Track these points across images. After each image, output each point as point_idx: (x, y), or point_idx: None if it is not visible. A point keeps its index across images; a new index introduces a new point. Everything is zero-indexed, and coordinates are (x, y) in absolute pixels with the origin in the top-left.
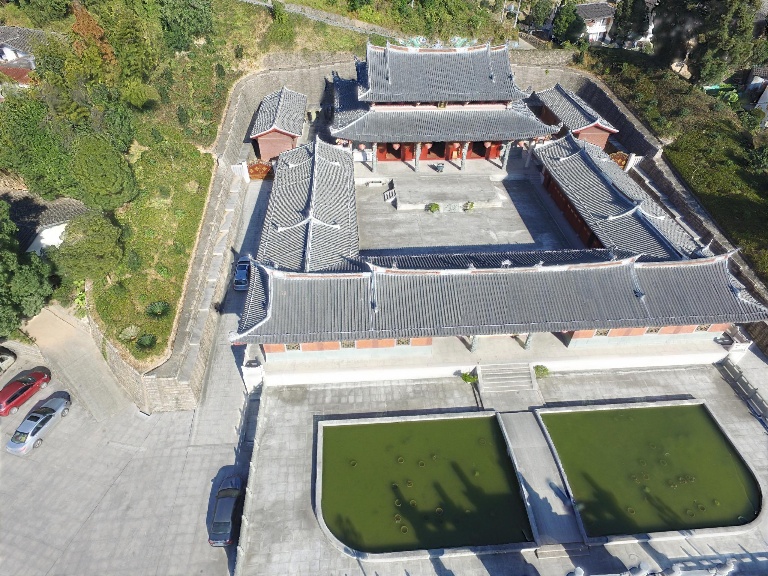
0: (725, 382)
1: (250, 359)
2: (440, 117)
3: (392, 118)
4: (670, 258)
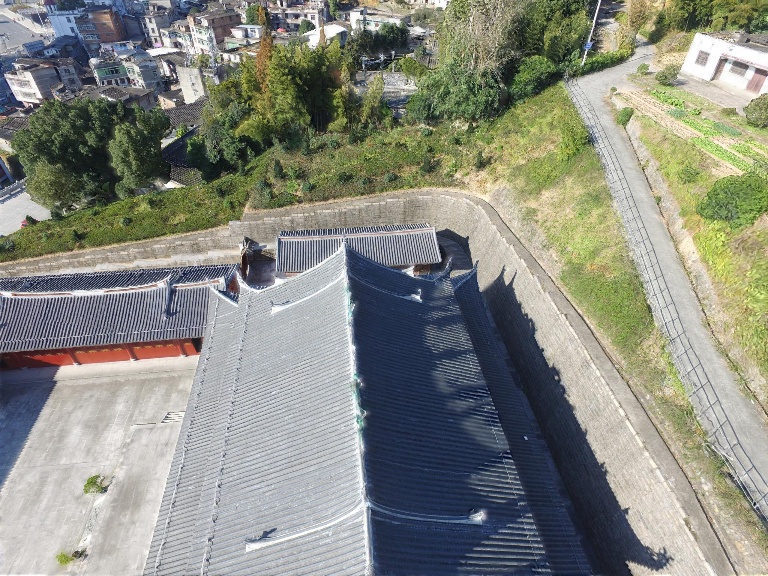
0: None
1: None
2: None
3: None
4: None
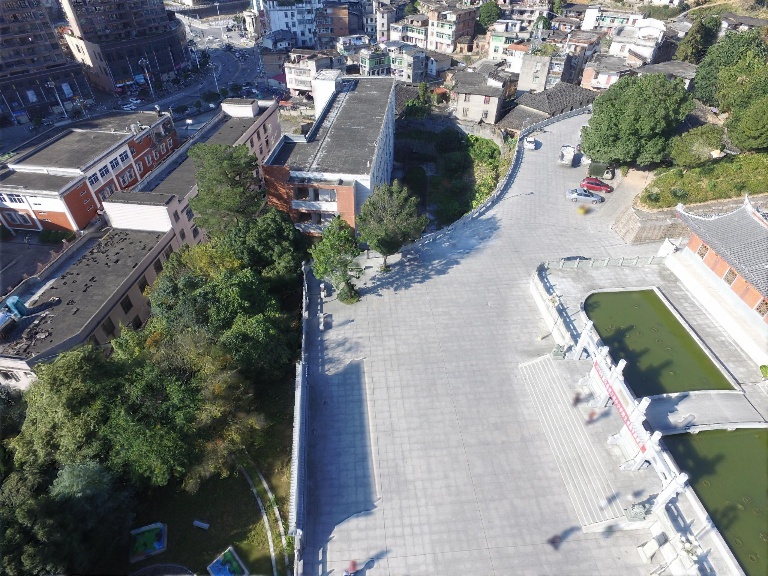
0: None
1: (678, 246)
2: None
3: None
4: None
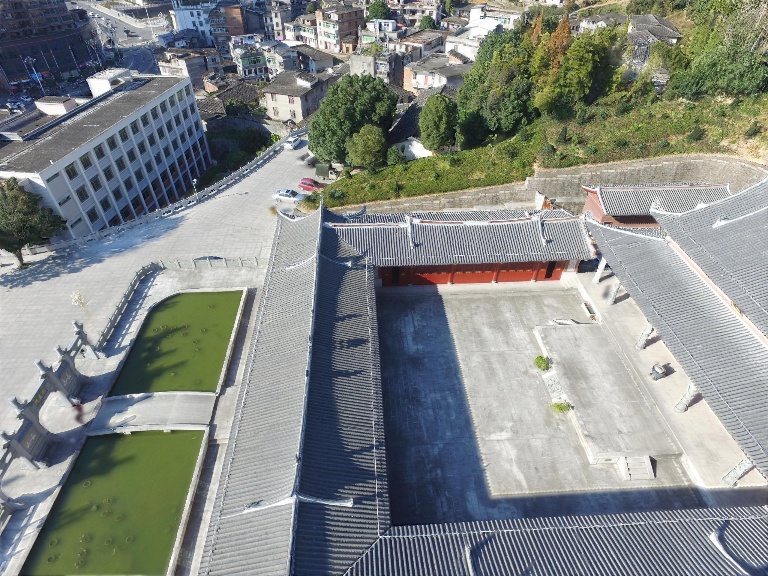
0: None
1: None
2: (716, 316)
3: (669, 264)
4: None
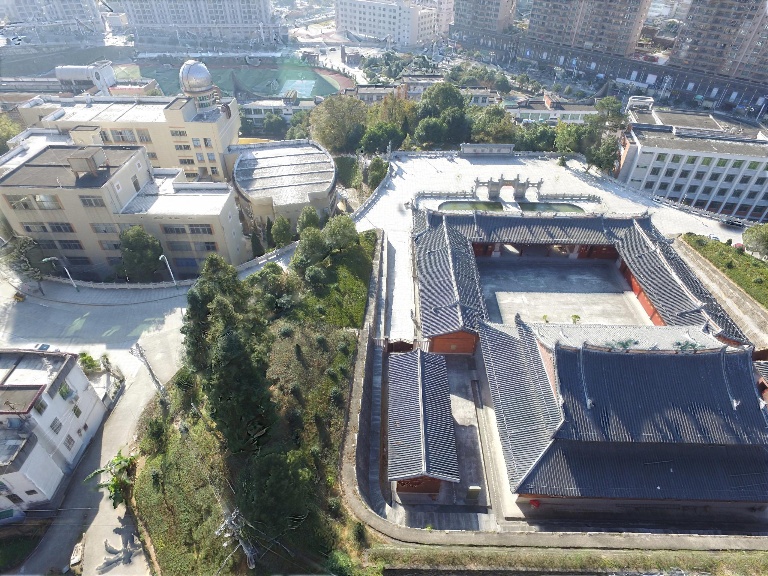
0: None
1: None
2: None
3: None
4: (448, 223)
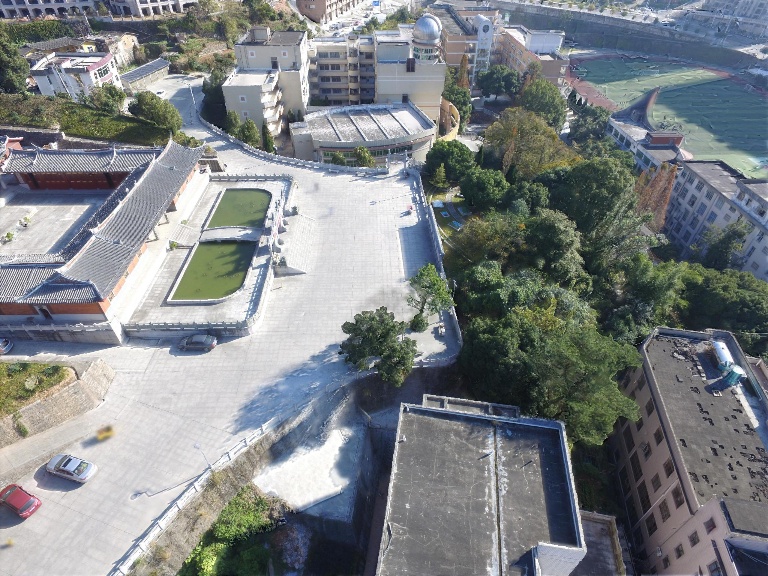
0: (219, 182)
1: None
2: None
3: None
4: (157, 154)
